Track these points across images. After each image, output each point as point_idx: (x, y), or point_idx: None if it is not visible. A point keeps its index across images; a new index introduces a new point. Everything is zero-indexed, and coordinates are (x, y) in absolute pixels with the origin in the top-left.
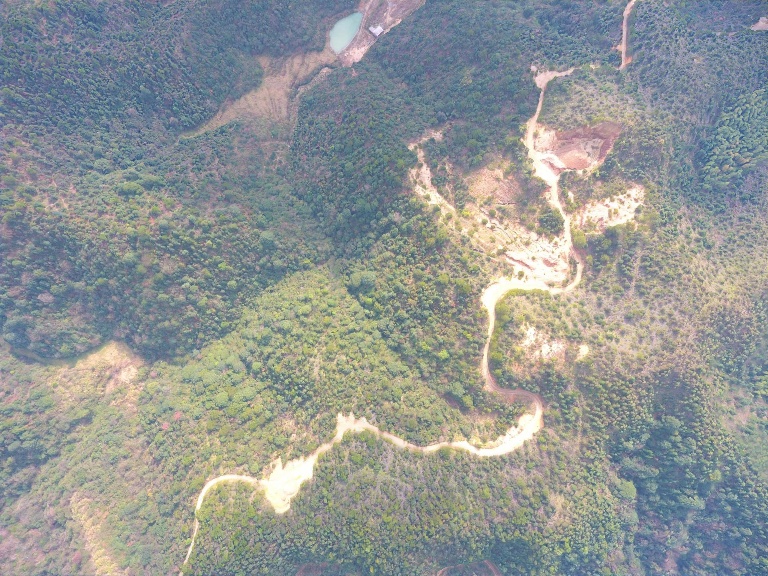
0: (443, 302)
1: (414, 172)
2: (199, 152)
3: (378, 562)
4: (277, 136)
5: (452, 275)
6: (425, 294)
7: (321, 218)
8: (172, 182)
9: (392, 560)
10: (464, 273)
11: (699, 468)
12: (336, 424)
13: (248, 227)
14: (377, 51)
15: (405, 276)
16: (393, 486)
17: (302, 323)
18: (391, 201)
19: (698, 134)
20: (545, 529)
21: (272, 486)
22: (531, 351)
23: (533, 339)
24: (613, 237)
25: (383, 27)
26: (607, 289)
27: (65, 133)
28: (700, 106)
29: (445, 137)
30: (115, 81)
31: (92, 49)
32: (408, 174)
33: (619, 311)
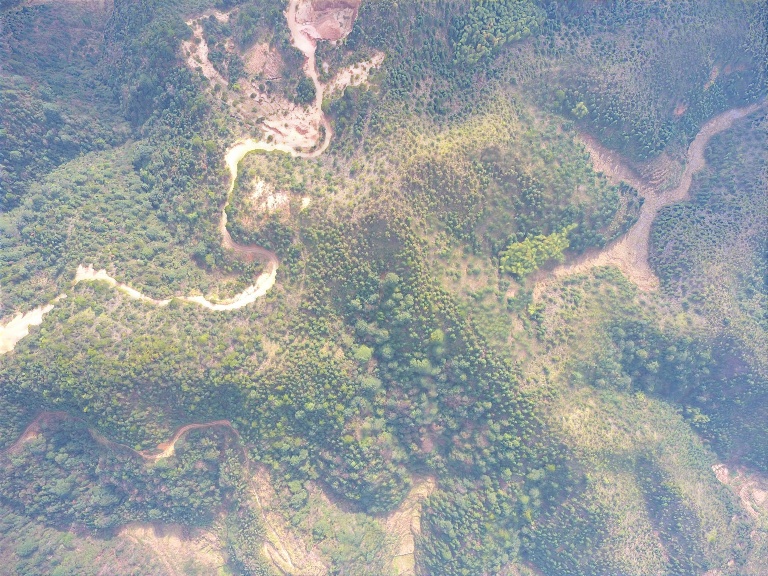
0: (197, 165)
1: (188, 44)
2: None
3: (83, 397)
4: (91, 25)
5: (206, 138)
6: (183, 158)
7: (120, 101)
8: None
9: None
10: (215, 135)
11: (420, 326)
12: (75, 275)
13: (31, 97)
14: None
15: (173, 145)
16: (110, 327)
17: (73, 190)
18: (169, 75)
19: (446, 9)
20: (255, 373)
21: (7, 333)
22: (258, 203)
23: (261, 191)
24: (348, 98)
25: None
26: (343, 150)
27: None
28: None
29: (231, 19)
30: None
31: None
32: (181, 46)
33: (347, 168)
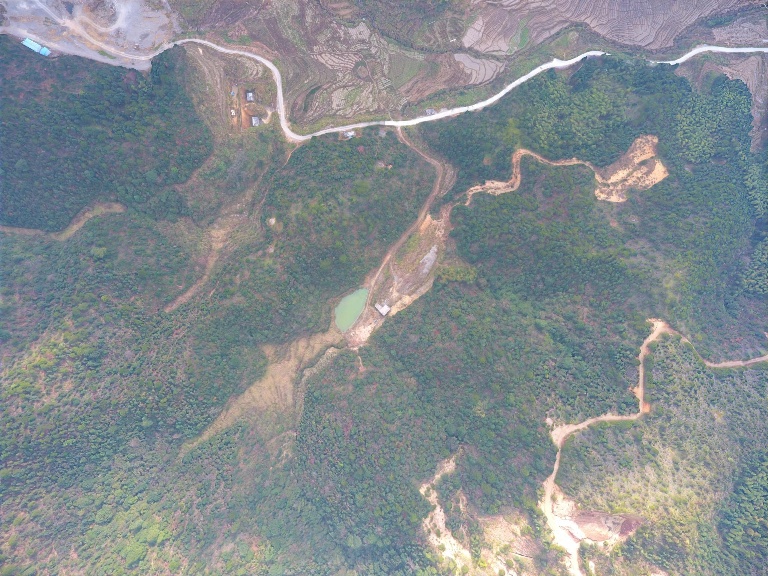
0: None
1: (428, 521)
2: (204, 478)
3: None
4: None
5: None
6: None
7: (330, 528)
8: (177, 534)
9: None
10: None
11: None
12: None
13: (256, 564)
14: (384, 339)
15: None
16: None
17: None
18: (404, 543)
19: (722, 509)
20: None
21: None
22: None
23: None
24: None
25: (389, 303)
26: None
27: (65, 488)
28: None
29: (458, 466)
30: (116, 422)
31: (92, 393)
32: (422, 524)
33: None
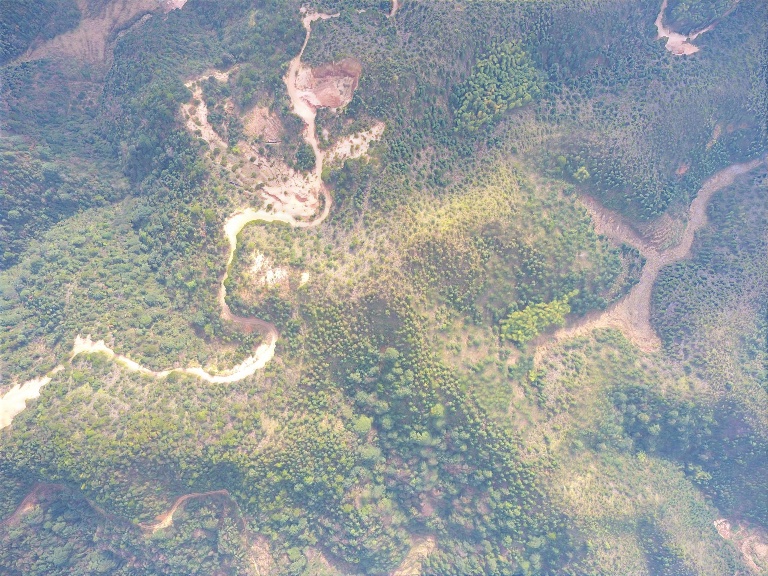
0: (196, 233)
1: (187, 107)
2: None
3: (81, 477)
4: (90, 77)
5: (205, 206)
6: (182, 225)
7: (119, 157)
8: None
9: (95, 475)
10: (214, 203)
11: (420, 401)
12: (73, 346)
13: (30, 157)
14: None
15: (172, 209)
16: (108, 404)
17: (72, 252)
18: (168, 136)
19: (447, 77)
20: (254, 452)
21: (4, 404)
22: (257, 277)
23: (260, 266)
24: (348, 170)
25: None
26: (343, 222)
27: None
28: (449, 50)
29: (231, 78)
30: None
31: None
32: (180, 109)
33: (346, 242)
